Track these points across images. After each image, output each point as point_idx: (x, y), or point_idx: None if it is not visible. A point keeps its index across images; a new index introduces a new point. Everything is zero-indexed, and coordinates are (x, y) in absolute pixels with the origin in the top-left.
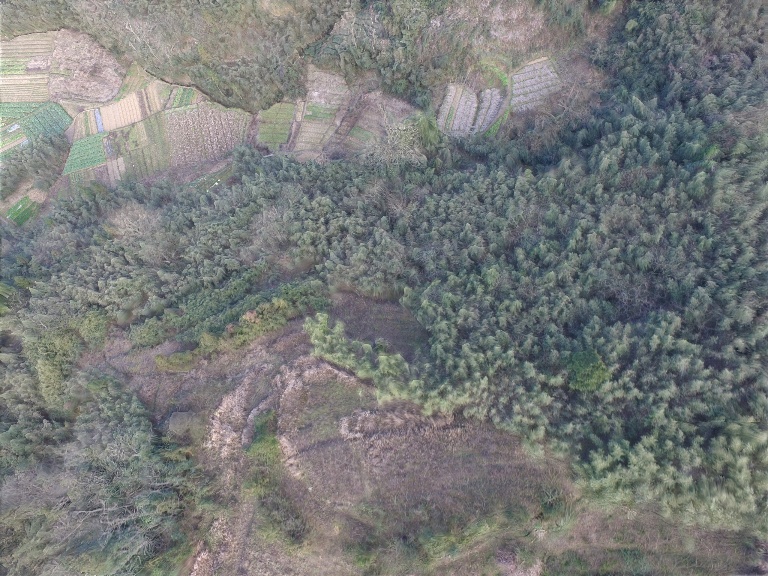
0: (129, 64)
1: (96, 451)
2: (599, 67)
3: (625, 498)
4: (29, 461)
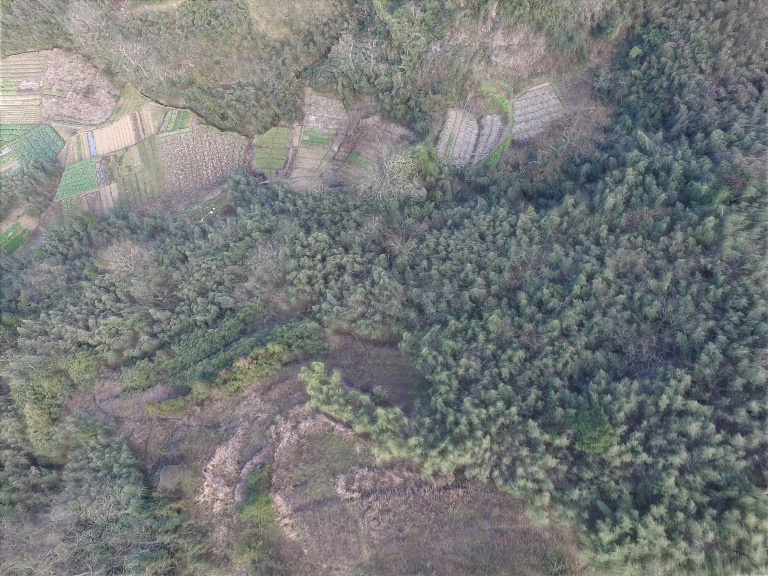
0: (123, 85)
1: (84, 504)
2: (602, 94)
3: (634, 573)
4: (16, 510)
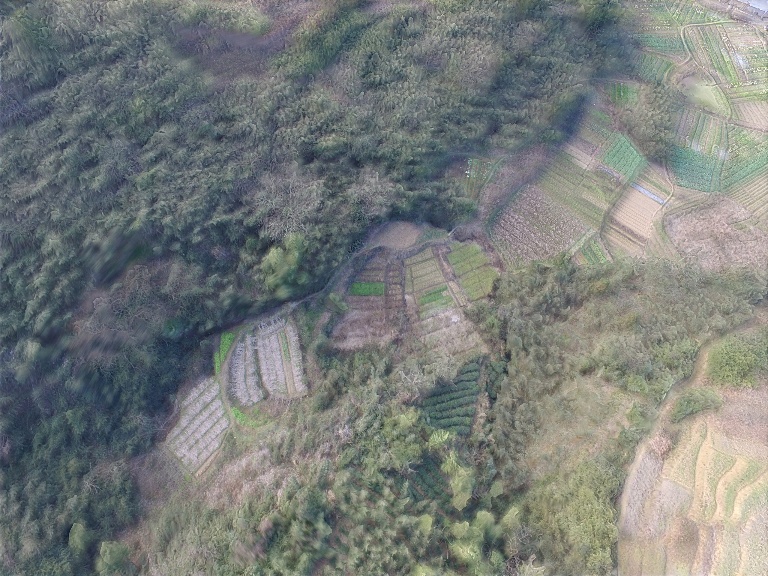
0: None
1: None
2: None
3: None
4: None
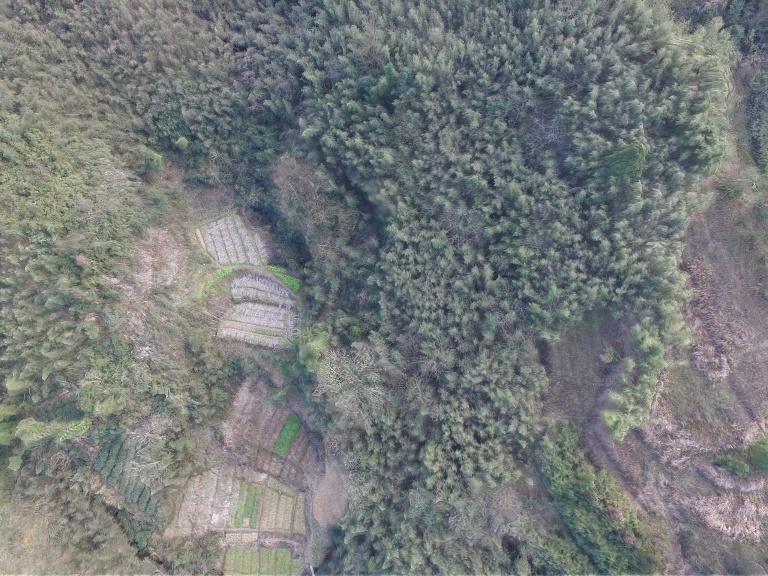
0: None
1: None
2: (224, 177)
3: None
4: None
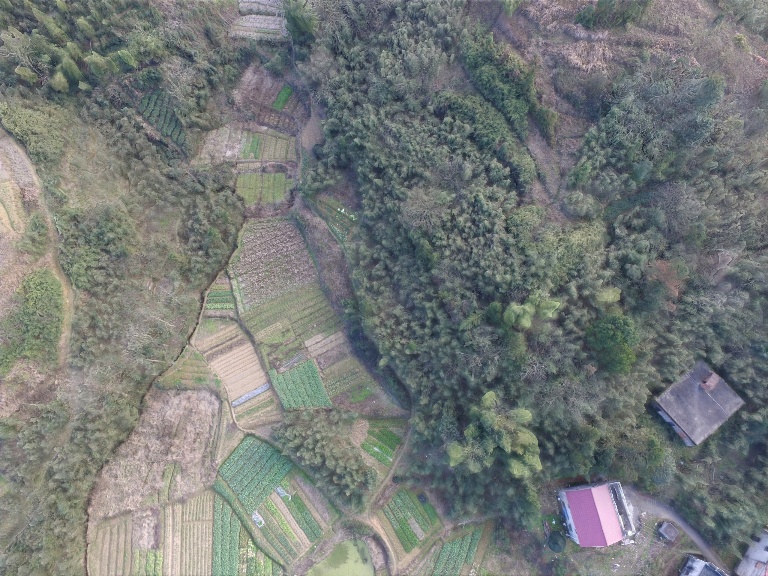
0: (161, 390)
1: None
2: None
3: None
4: (651, 234)
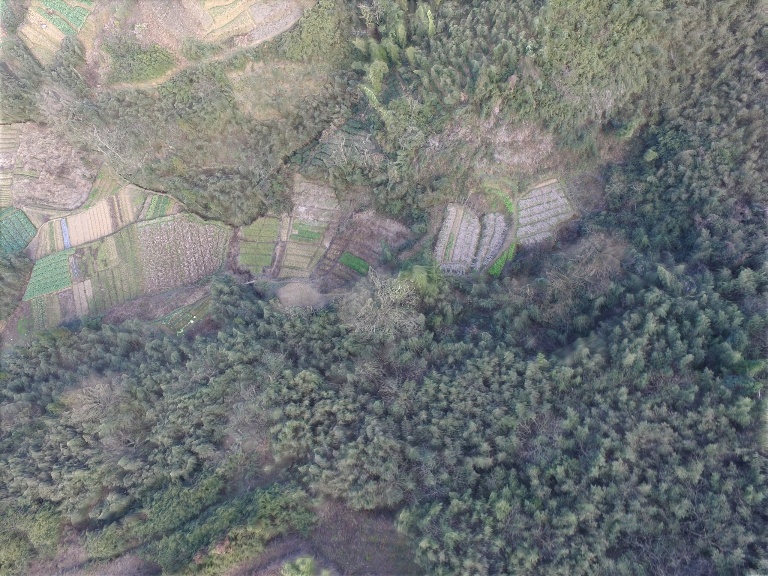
0: (100, 164)
1: None
2: (614, 199)
3: None
4: None
